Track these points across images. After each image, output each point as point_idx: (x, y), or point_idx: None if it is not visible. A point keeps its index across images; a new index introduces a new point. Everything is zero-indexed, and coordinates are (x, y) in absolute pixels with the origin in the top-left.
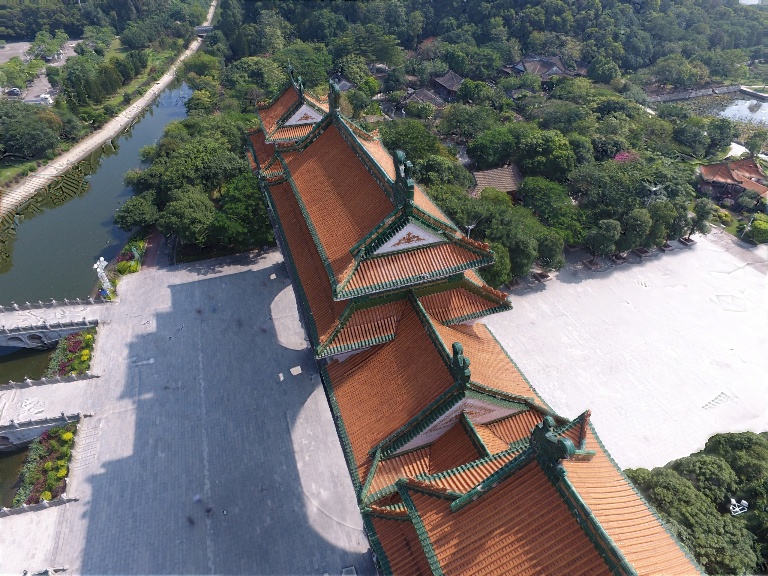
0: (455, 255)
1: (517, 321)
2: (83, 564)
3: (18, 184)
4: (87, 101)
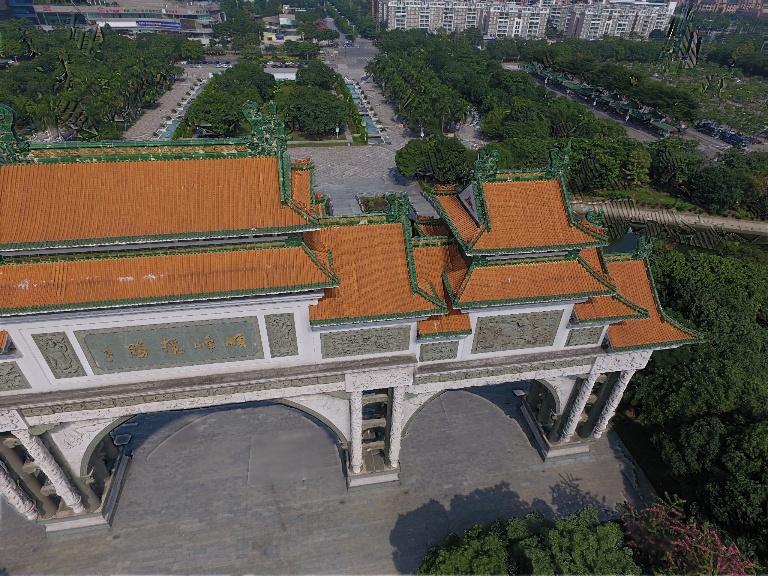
0: None
1: None
2: None
3: (651, 209)
4: None
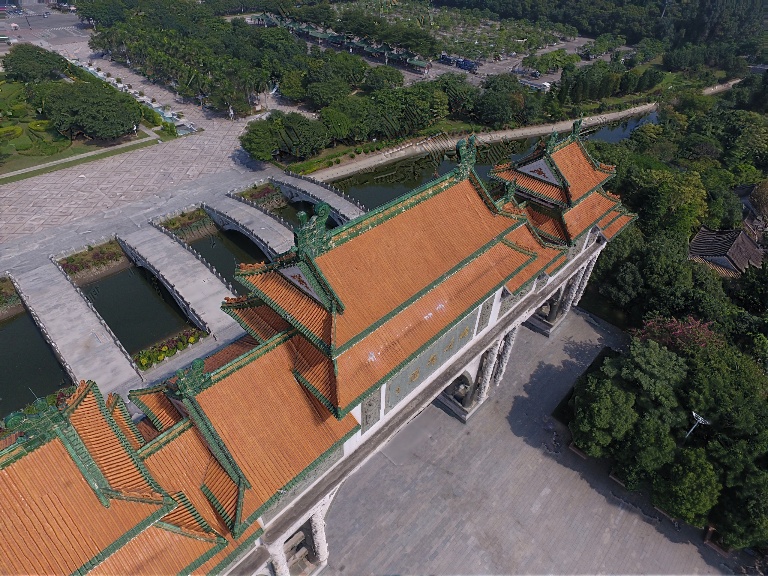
0: (322, 325)
1: (650, 570)
2: (222, 345)
3: (459, 137)
4: (567, 98)
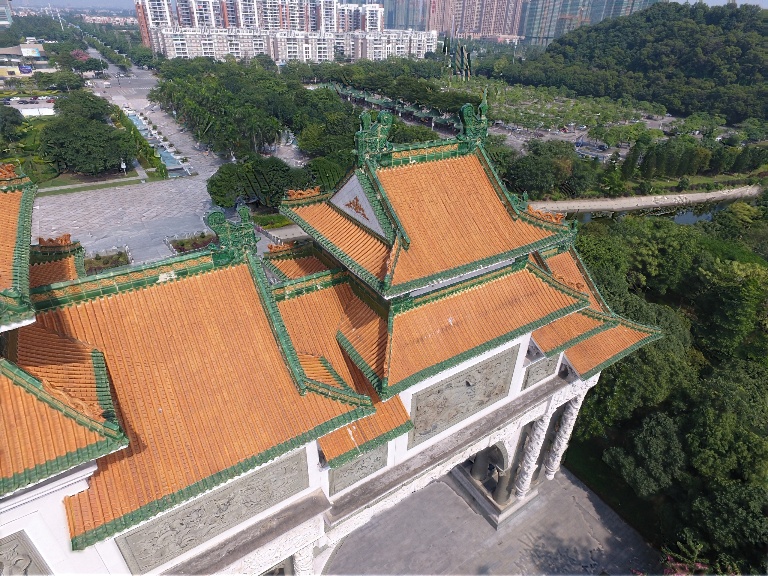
0: None
1: None
2: None
3: None
4: (635, 172)
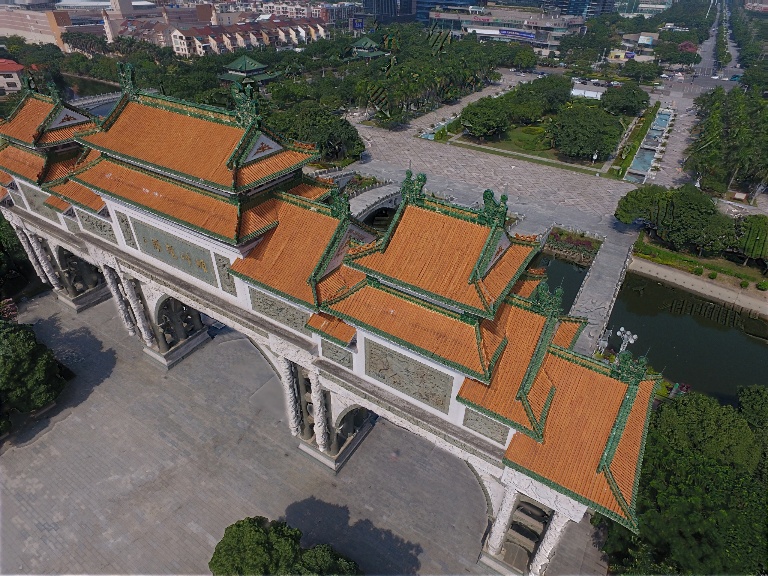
0: None
1: None
2: None
3: None
4: None
